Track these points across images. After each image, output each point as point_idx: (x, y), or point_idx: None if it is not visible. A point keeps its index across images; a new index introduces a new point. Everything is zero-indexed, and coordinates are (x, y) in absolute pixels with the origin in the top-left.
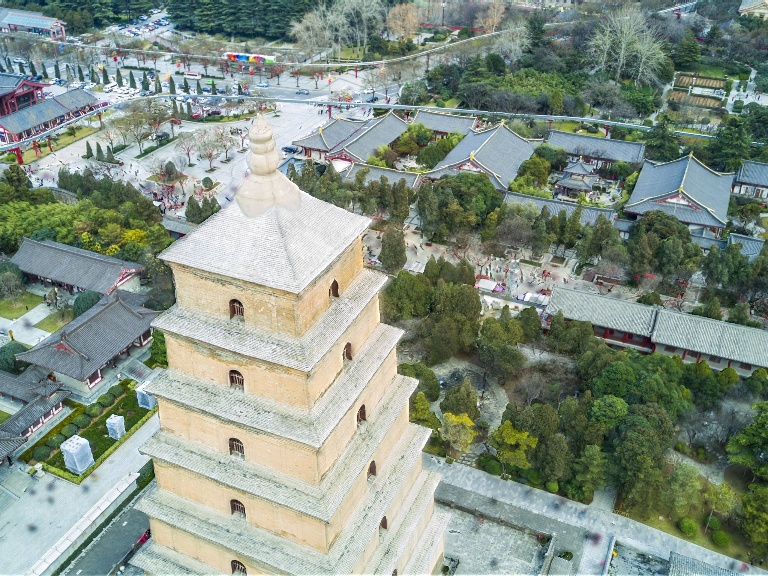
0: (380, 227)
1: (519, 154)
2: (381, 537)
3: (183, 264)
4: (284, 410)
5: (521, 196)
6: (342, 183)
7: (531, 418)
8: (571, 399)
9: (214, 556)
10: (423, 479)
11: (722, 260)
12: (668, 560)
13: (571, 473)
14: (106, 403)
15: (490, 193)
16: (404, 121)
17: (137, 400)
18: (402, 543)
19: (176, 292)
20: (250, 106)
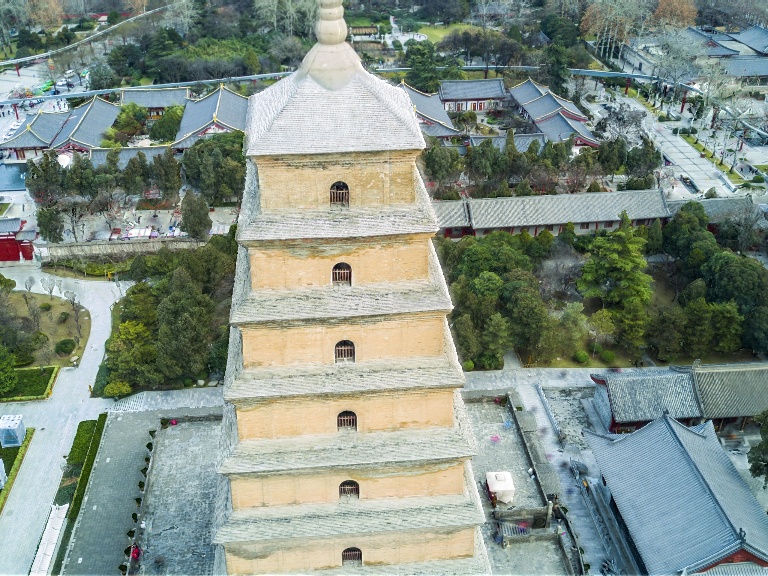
0: (158, 203)
1: None
2: None
3: (281, 154)
4: (402, 287)
5: None
6: (94, 169)
7: None
8: (456, 285)
9: (317, 489)
10: None
11: (484, 155)
12: (584, 386)
13: (481, 347)
14: None
15: None
16: (113, 104)
17: None
18: None
19: (259, 196)
20: None
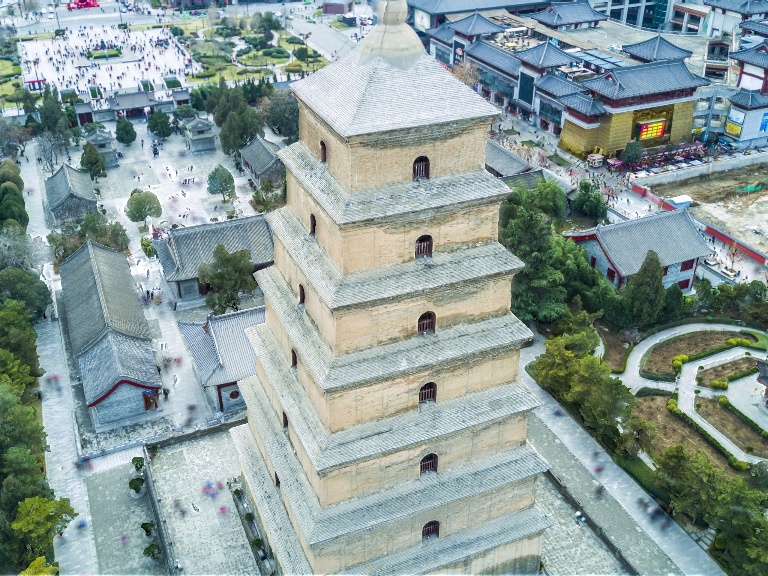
0: None
1: None
2: None
3: None
4: None
5: None
6: None
7: None
8: None
9: None
10: None
11: None
12: None
13: None
14: None
15: None
16: None
17: None
18: None
19: None
20: None
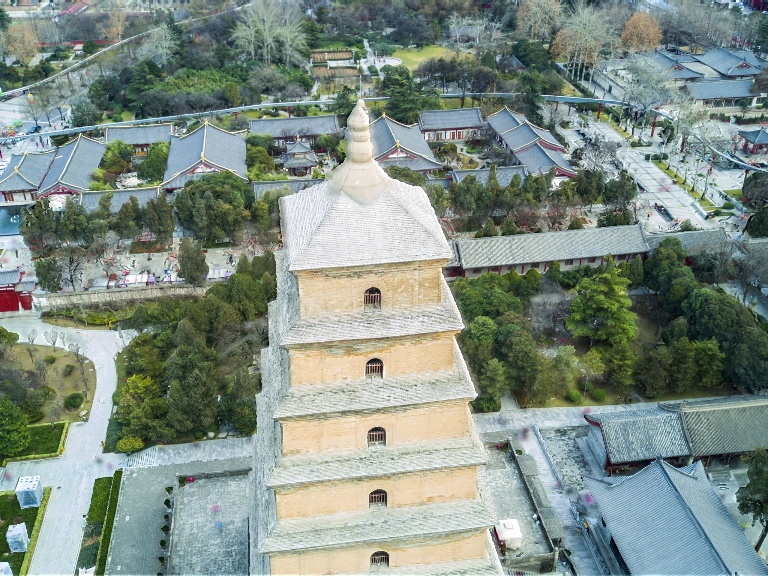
0: (152, 247)
1: (235, 148)
2: None
3: (321, 268)
4: (429, 378)
5: (269, 183)
6: (88, 215)
7: None
8: None
9: (350, 560)
10: None
11: (468, 191)
12: (578, 425)
13: (479, 391)
14: None
15: (242, 187)
16: (98, 142)
17: (14, 504)
18: None
19: (298, 303)
20: None
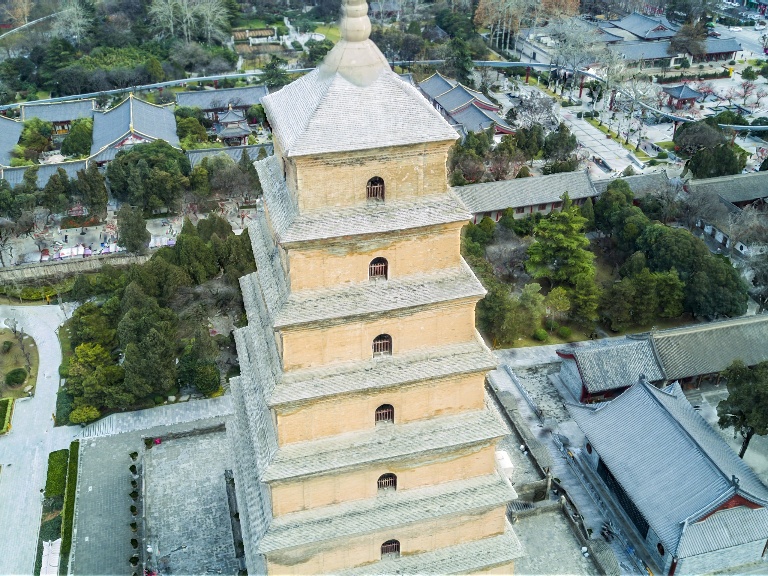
0: (86, 220)
1: (164, 120)
2: None
3: (323, 152)
4: (436, 277)
5: (204, 151)
6: (12, 189)
7: None
8: None
9: (357, 486)
10: None
11: None
12: (548, 363)
13: None
14: None
15: (177, 156)
16: (14, 120)
17: None
18: None
19: (297, 197)
20: None
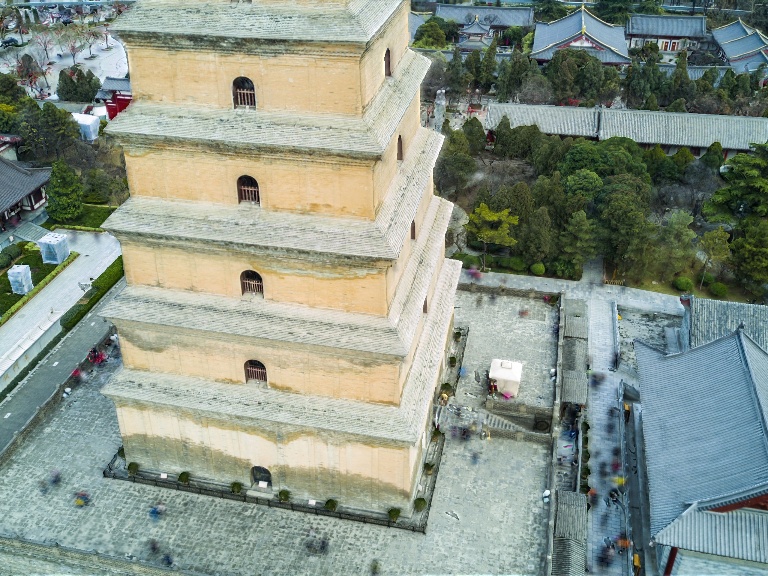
0: None
1: (411, 24)
2: (411, 246)
3: None
4: (311, 11)
5: (426, 51)
6: None
7: (506, 199)
8: (543, 178)
9: (216, 275)
10: (436, 203)
11: (644, 75)
12: (674, 314)
13: (557, 250)
14: (1, 263)
15: None
16: None
17: (40, 258)
18: (433, 257)
19: None
20: (105, 15)
